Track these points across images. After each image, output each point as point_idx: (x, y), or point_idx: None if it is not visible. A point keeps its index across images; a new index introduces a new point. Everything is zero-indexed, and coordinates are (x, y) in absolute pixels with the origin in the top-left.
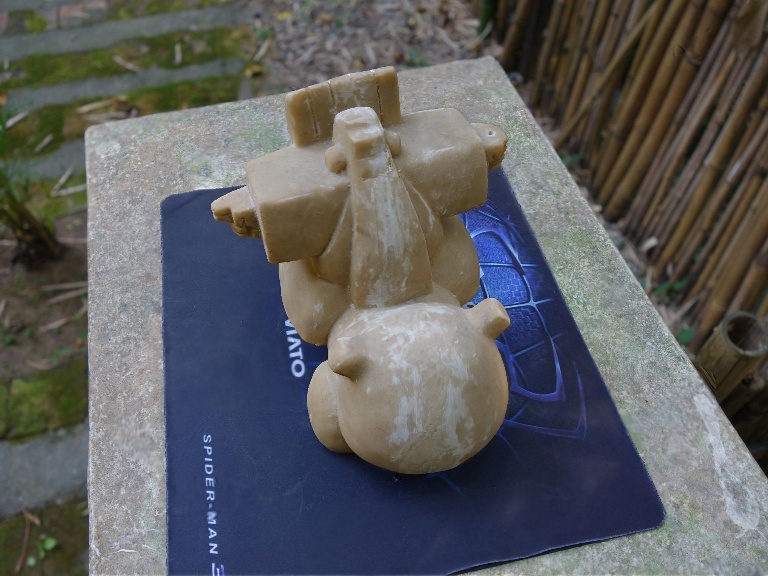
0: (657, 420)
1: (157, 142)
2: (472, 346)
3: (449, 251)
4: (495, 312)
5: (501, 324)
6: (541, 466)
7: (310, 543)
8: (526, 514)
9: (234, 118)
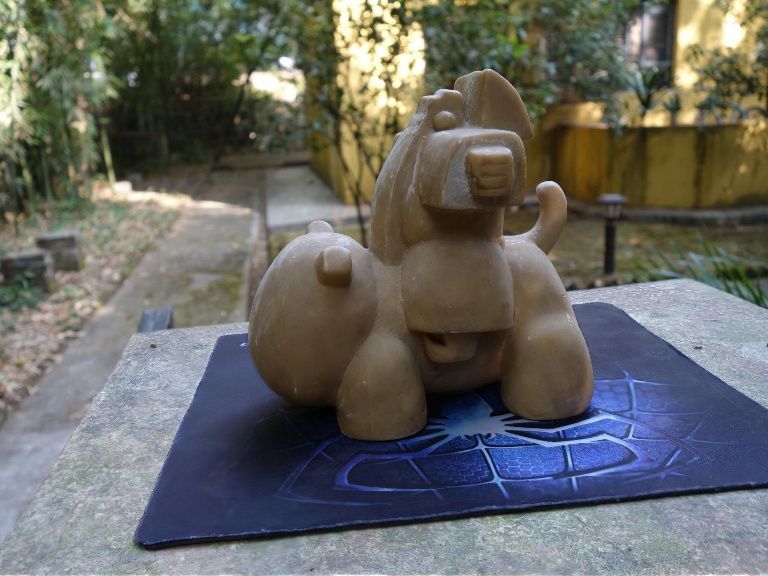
0: (278, 574)
1: (688, 298)
2: (301, 252)
3: (422, 250)
4: (327, 247)
5: (321, 261)
6: (257, 464)
7: (252, 367)
8: (212, 451)
9: (758, 320)
